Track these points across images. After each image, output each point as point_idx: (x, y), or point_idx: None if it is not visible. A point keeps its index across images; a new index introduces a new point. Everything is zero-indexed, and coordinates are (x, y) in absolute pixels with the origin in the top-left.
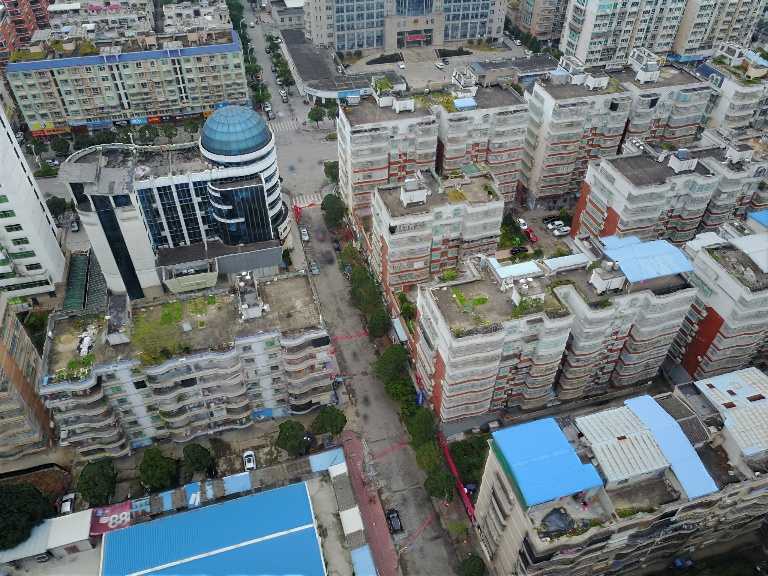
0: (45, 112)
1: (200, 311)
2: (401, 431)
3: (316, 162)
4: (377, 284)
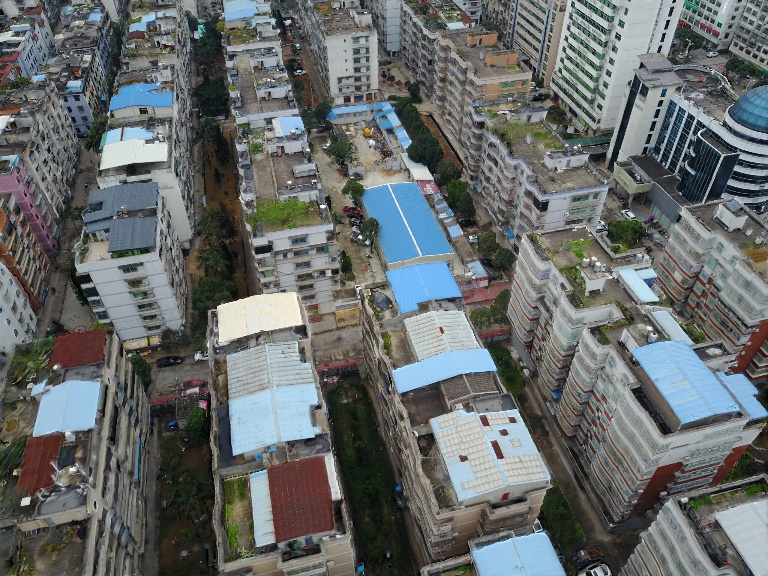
0: None
1: (546, 144)
2: None
3: None
4: None
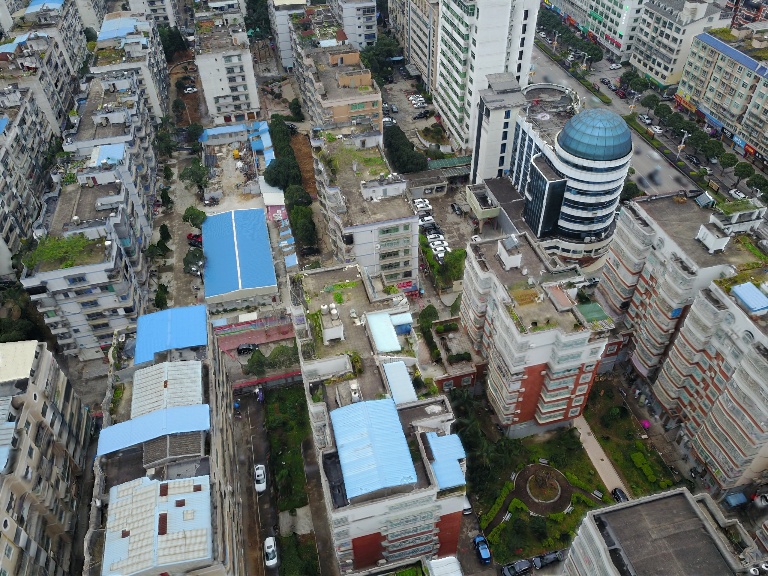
0: (693, 85)
1: (372, 171)
2: None
3: None
4: None
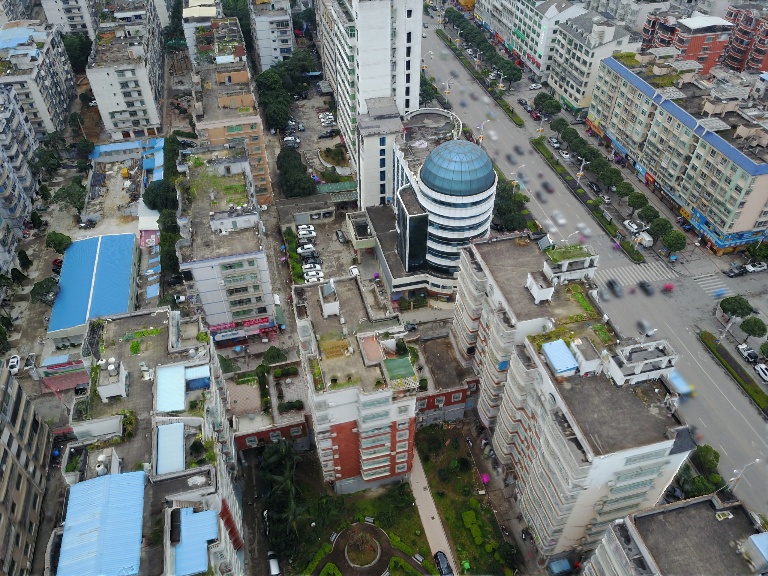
0: (601, 109)
1: (230, 201)
2: None
3: (630, 323)
4: None
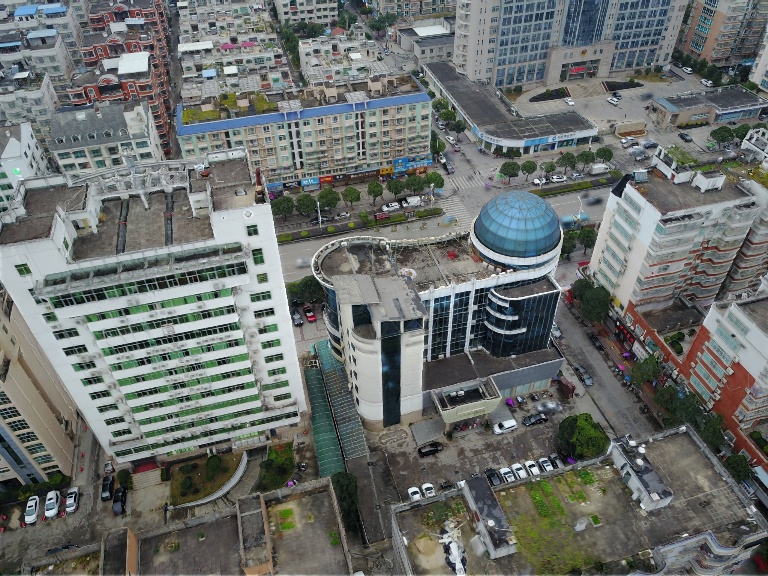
0: None
1: (582, 497)
2: None
3: None
4: (706, 413)
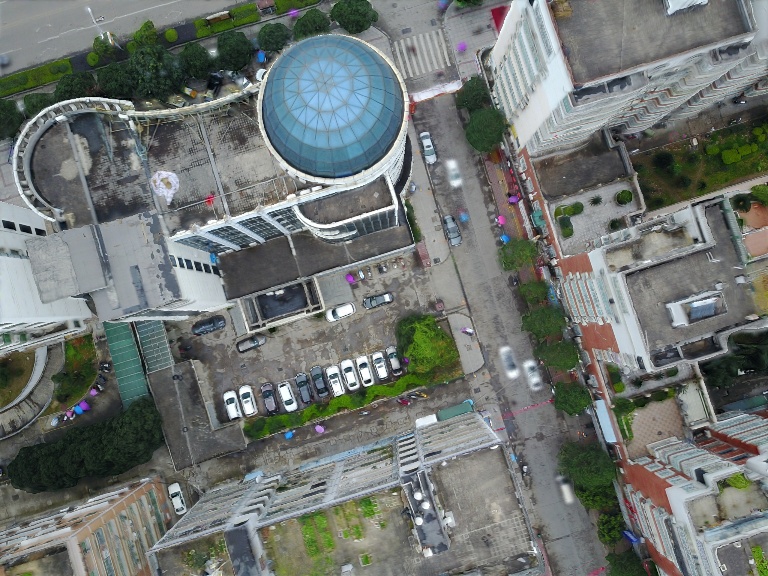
0: None
1: (356, 533)
2: (588, 524)
3: None
4: (570, 327)
